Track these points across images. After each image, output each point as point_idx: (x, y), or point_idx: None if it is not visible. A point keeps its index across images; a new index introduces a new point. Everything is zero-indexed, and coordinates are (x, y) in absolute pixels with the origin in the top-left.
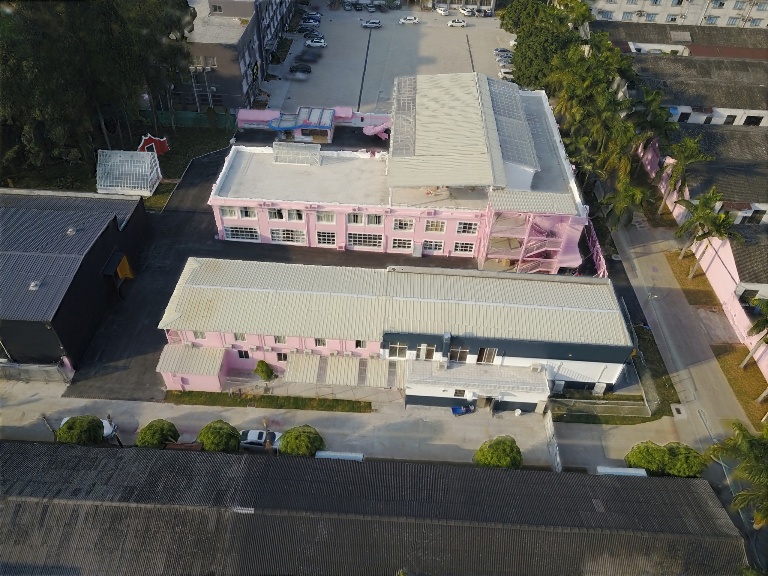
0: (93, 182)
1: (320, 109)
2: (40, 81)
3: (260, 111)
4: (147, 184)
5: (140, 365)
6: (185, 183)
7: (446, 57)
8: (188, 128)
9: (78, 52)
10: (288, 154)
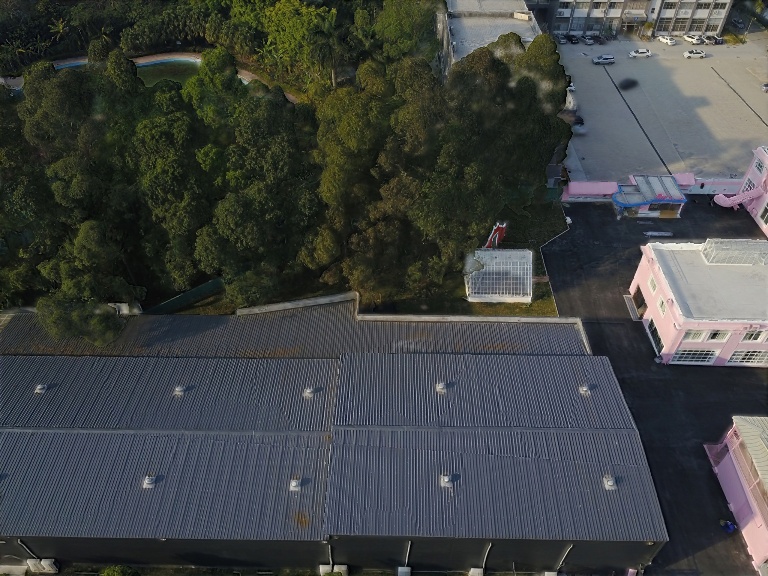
0: (450, 286)
1: (656, 177)
2: (477, 189)
3: (594, 183)
4: (530, 289)
5: (711, 567)
6: (557, 282)
7: (712, 97)
8: (505, 205)
9: (514, 150)
10: (731, 254)
